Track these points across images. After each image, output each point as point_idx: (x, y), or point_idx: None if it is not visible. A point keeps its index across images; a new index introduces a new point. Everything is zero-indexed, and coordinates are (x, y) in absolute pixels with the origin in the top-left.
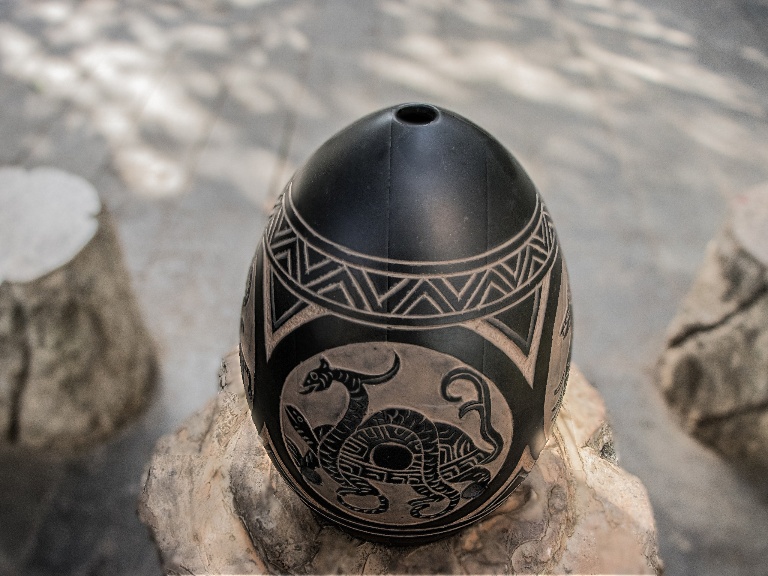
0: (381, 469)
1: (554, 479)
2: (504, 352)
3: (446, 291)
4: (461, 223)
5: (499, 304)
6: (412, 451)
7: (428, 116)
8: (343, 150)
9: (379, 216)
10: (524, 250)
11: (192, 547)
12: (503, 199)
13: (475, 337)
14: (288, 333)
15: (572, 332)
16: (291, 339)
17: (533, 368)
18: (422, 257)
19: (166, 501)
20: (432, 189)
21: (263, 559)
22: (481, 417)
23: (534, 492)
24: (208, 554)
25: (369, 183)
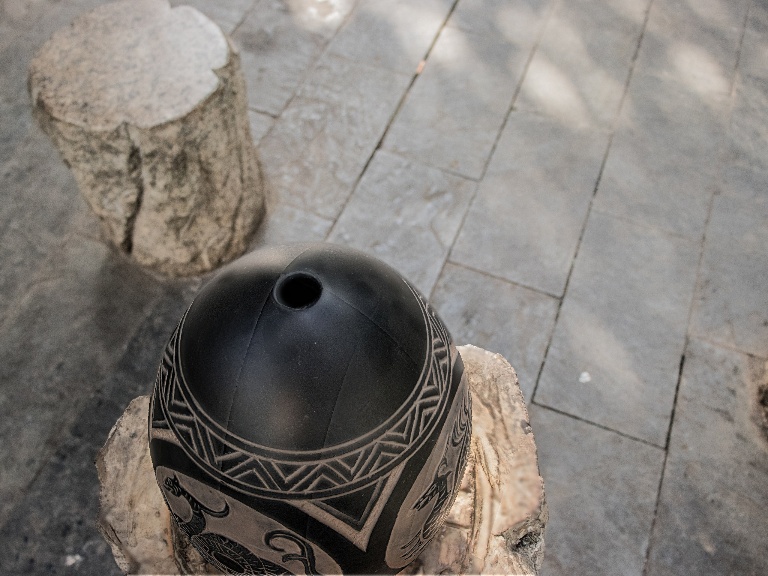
0: (222, 564)
1: (449, 562)
2: (331, 527)
3: (274, 473)
4: (300, 420)
5: (328, 492)
6: (243, 567)
7: (316, 288)
8: (225, 302)
9: (227, 390)
10: (370, 448)
11: (124, 511)
12: (357, 400)
13: (299, 513)
14: (158, 438)
15: (443, 495)
16: (159, 444)
17: (367, 538)
18: (256, 439)
19: (119, 460)
20: (279, 381)
21: (173, 544)
22: (305, 565)
23: (422, 570)
24: (134, 522)
25: (228, 354)
